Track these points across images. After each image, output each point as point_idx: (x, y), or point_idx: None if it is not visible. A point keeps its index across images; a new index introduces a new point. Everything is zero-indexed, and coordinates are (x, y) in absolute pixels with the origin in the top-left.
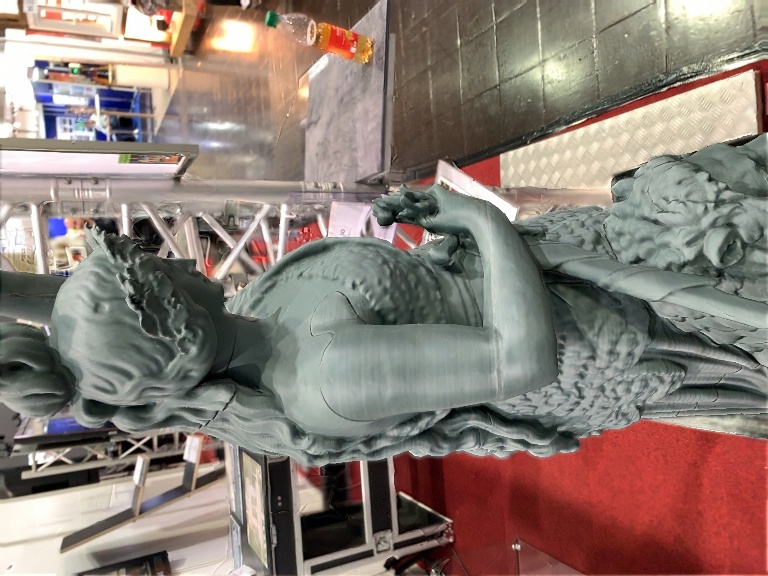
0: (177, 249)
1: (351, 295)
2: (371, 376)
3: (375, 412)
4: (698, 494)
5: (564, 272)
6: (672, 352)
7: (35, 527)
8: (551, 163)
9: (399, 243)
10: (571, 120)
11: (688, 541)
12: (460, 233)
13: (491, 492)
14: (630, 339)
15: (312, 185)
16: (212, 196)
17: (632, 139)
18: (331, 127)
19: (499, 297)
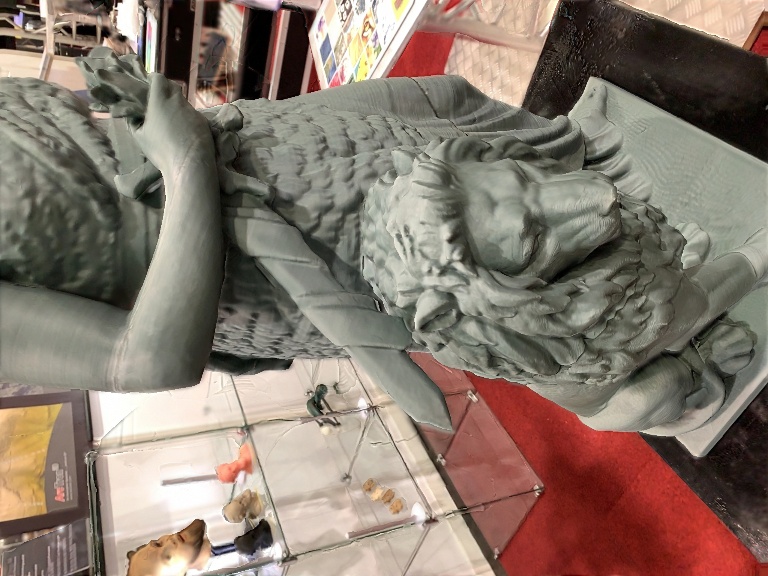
0: None
1: None
2: None
3: None
4: None
5: (262, 265)
6: None
7: None
8: None
9: None
10: None
11: None
12: None
13: None
14: None
15: None
16: None
17: None
18: None
19: (147, 295)
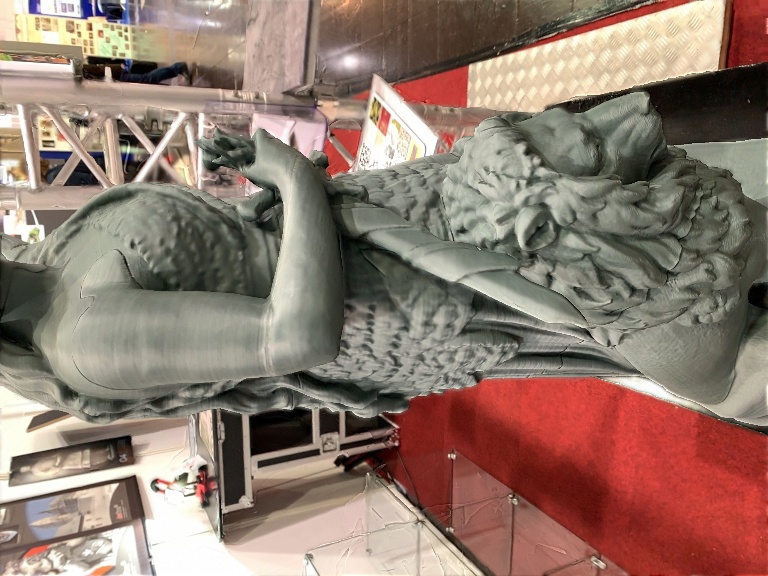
0: (84, 155)
1: (129, 255)
2: (124, 348)
3: (135, 383)
4: (614, 425)
5: (371, 241)
6: (504, 323)
7: (0, 407)
8: (517, 79)
9: (338, 159)
10: (542, 33)
11: (600, 467)
12: (275, 188)
13: (435, 404)
14: (449, 311)
15: (231, 94)
16: (119, 100)
17: (597, 60)
18: (266, 27)
19: (283, 268)
